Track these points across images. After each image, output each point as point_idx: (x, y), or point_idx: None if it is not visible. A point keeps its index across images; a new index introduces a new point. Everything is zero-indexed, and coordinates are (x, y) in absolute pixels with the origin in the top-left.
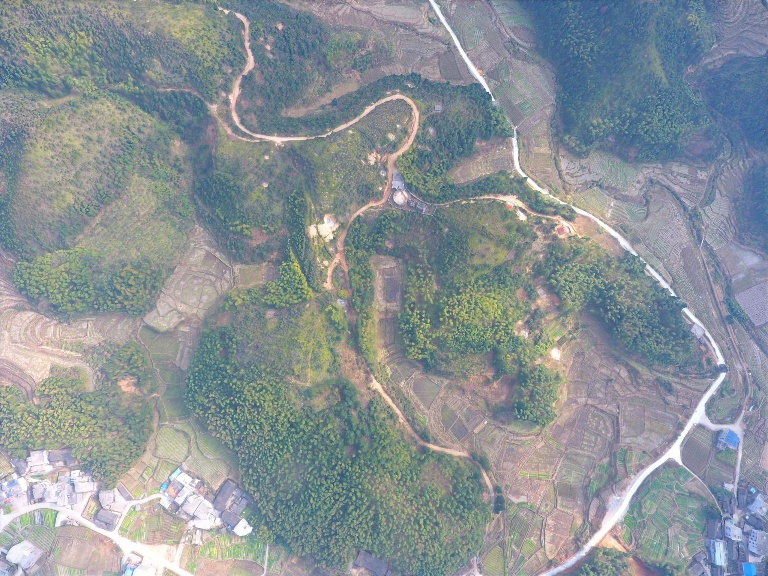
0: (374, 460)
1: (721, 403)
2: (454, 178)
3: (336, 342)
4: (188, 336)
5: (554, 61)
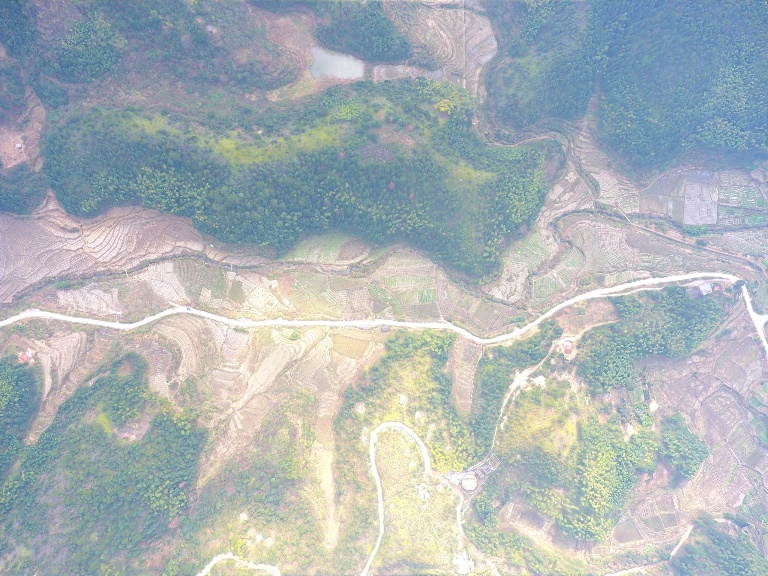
0: None
1: (759, 298)
2: (463, 408)
3: None
4: None
5: (396, 241)
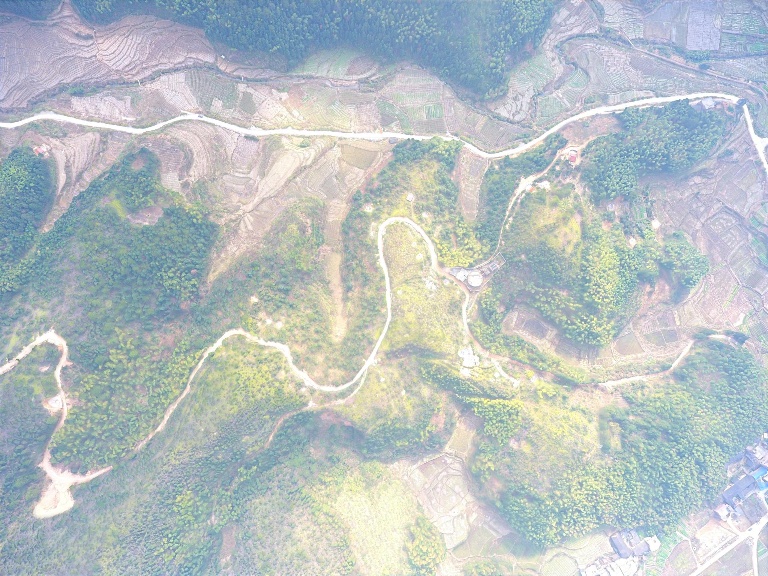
0: (683, 424)
1: (760, 121)
2: (469, 218)
3: (566, 401)
4: (481, 517)
5: (404, 57)
